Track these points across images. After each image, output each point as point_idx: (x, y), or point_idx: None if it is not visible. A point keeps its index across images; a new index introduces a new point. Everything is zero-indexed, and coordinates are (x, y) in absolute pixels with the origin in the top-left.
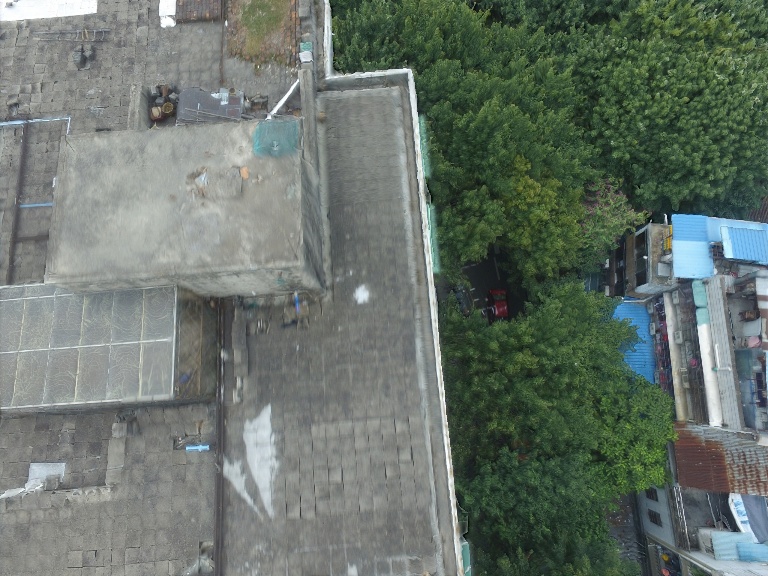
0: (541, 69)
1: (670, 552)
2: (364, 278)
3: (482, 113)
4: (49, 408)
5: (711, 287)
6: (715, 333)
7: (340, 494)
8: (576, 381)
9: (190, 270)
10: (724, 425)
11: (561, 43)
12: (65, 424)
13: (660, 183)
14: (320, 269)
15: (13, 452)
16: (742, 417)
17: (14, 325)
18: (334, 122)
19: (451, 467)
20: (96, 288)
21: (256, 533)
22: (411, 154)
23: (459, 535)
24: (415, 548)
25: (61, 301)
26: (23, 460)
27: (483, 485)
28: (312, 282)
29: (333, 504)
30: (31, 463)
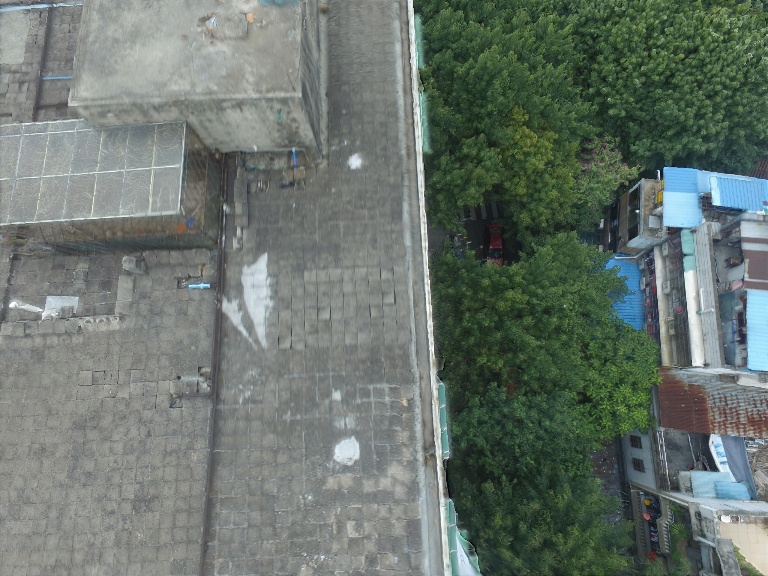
0: (542, 26)
1: (652, 498)
2: (357, 148)
3: (482, 58)
4: (68, 223)
5: (698, 235)
6: (701, 278)
7: (328, 330)
8: (565, 324)
9: (198, 96)
10: (706, 365)
11: (563, 5)
12: (79, 264)
13: (655, 141)
14: (317, 134)
15: (32, 287)
16: (723, 355)
17: (38, 155)
18: (335, 12)
19: (430, 311)
20: (113, 120)
21: (250, 360)
22: (406, 45)
23: (435, 369)
24: (394, 377)
25: (81, 135)
26: (40, 294)
27: (471, 417)
28: (309, 138)
29: (321, 338)
30: (48, 296)
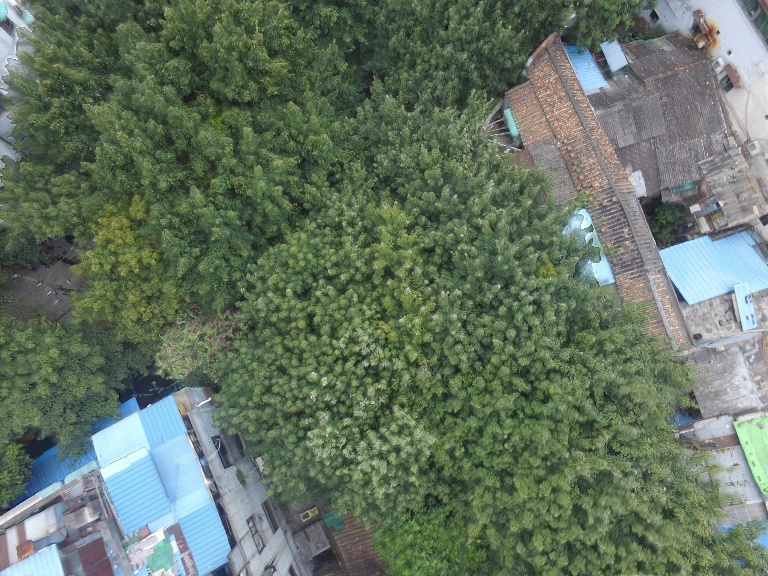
0: None
1: None
2: None
3: (84, 107)
4: None
5: None
6: None
7: None
8: None
9: None
10: None
11: None
12: None
13: None
14: None
15: None
16: None
17: None
18: None
19: None
20: None
21: None
22: None
23: None
24: None
25: None
26: None
27: None
28: None
29: None
30: None
